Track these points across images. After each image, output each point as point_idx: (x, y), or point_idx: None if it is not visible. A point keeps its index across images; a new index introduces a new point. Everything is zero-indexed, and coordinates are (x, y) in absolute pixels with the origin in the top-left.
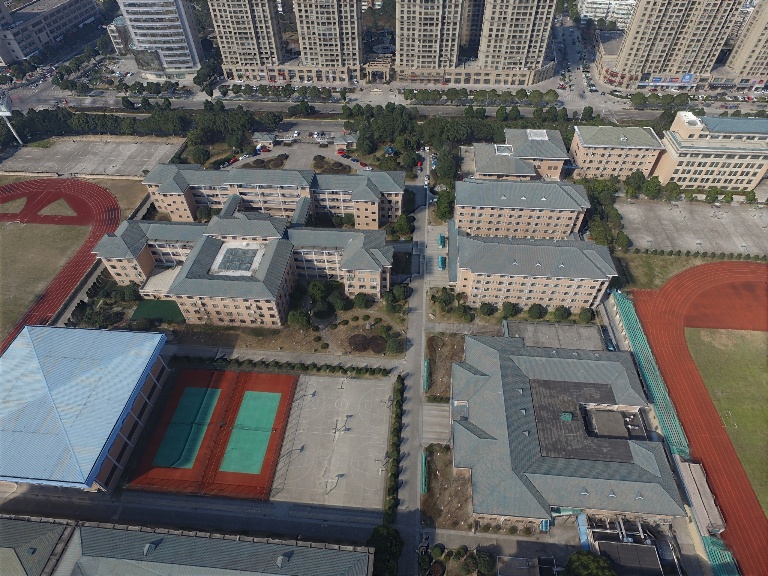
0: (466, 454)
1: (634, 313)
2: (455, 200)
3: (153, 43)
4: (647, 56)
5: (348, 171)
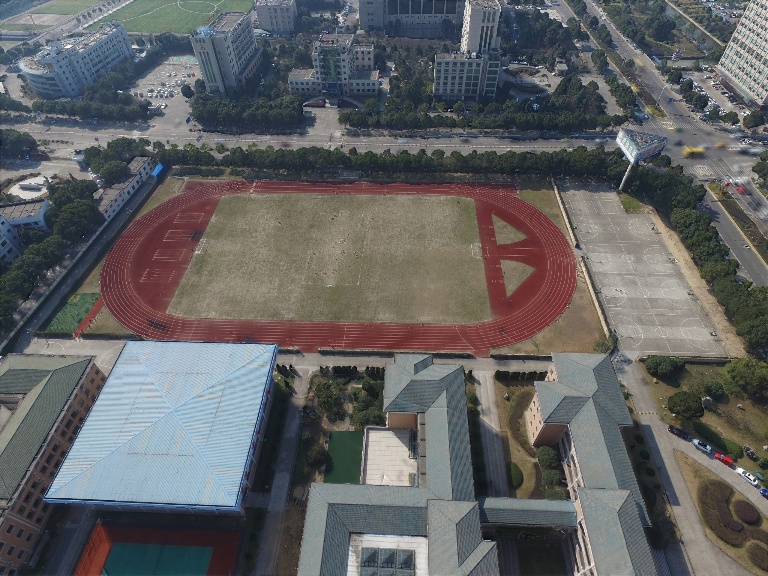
0: None
1: None
2: None
3: None
4: None
5: None
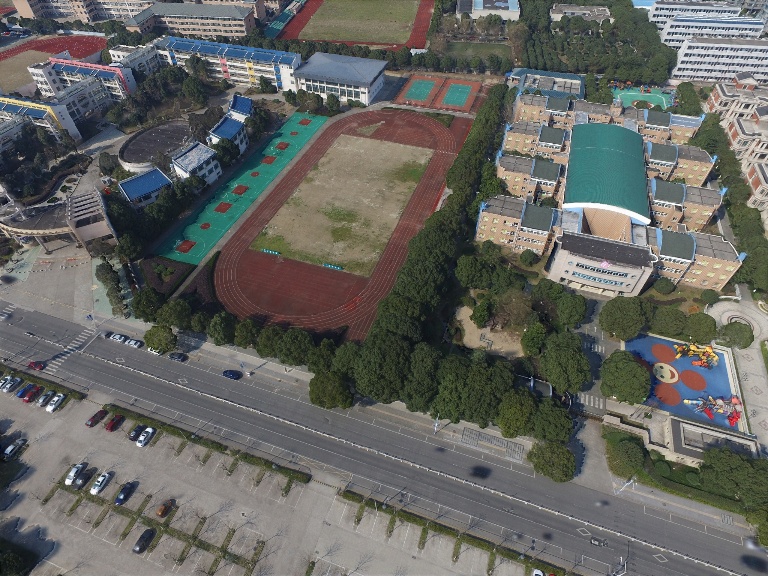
0: None
1: None
2: None
3: None
4: None
5: None
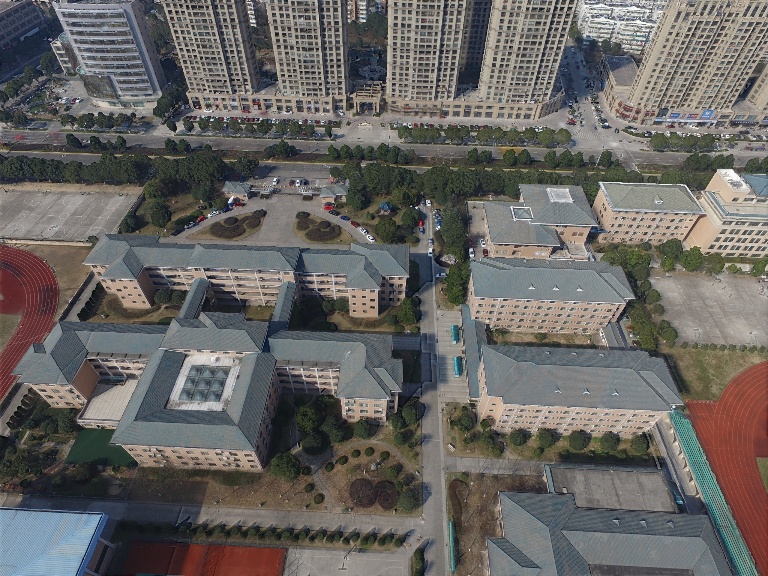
0: None
1: (695, 438)
2: (470, 282)
3: (104, 68)
4: (665, 90)
5: (338, 233)
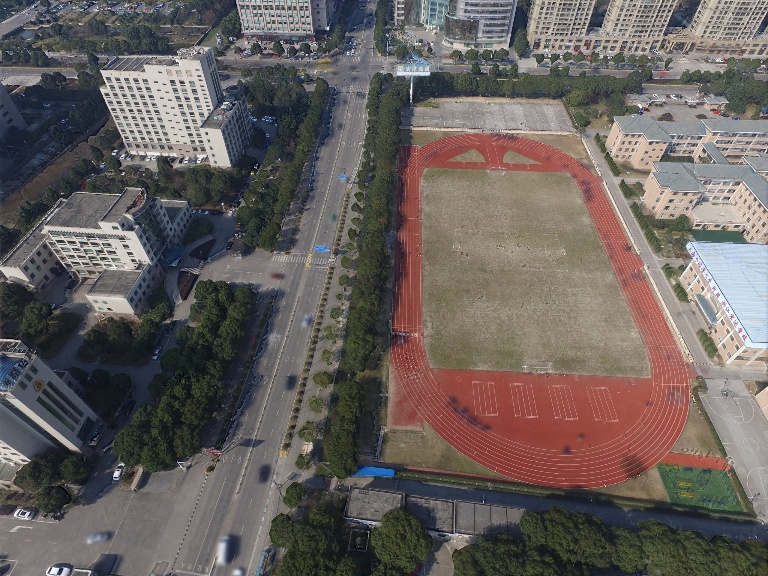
0: None
1: None
2: None
3: (480, 13)
4: None
5: None
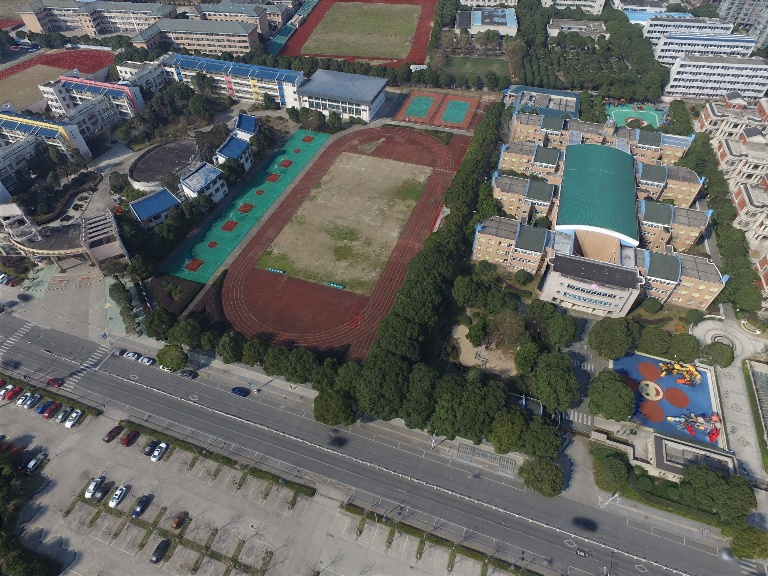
0: (220, 3)
1: None
2: None
3: None
4: None
5: None
